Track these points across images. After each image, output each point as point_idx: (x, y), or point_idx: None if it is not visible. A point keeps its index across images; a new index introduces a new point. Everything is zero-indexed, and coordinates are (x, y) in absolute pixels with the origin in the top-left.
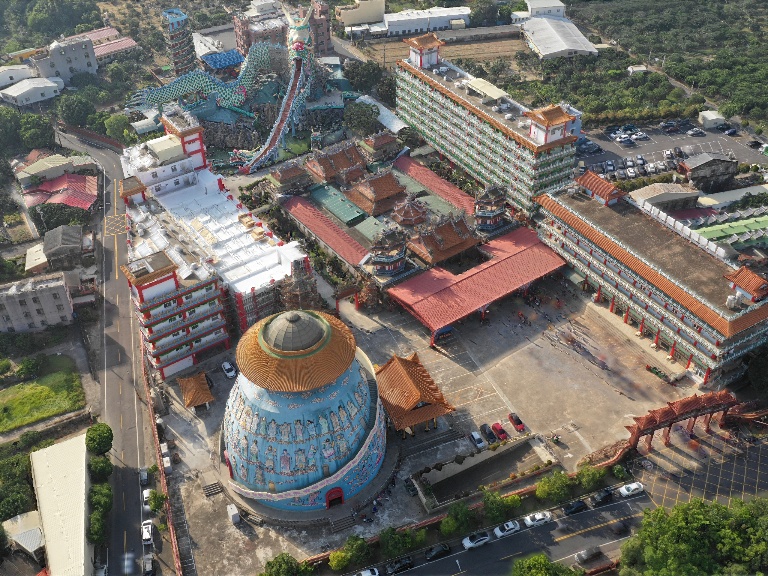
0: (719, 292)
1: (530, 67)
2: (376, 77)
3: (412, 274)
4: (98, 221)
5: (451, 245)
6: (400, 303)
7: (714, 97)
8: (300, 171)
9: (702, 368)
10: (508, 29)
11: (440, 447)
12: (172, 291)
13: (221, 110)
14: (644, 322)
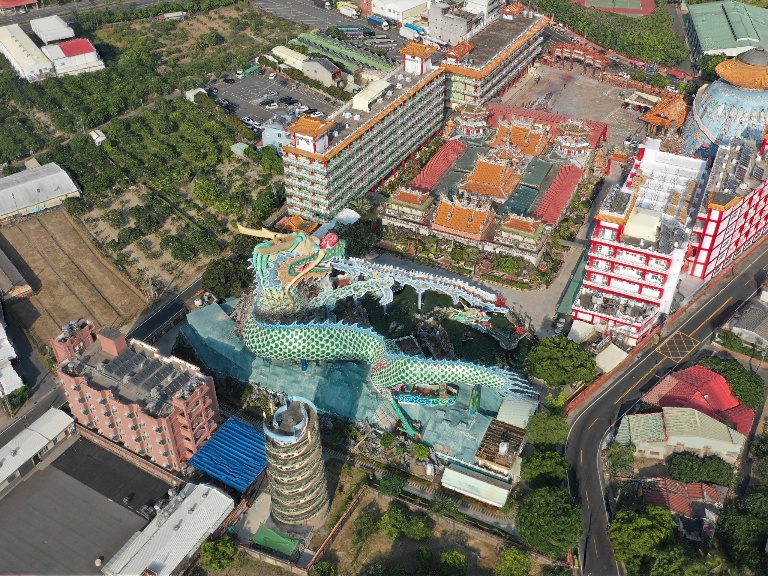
0: (522, 21)
1: None
2: None
3: None
4: (690, 364)
5: None
6: None
7: None
8: None
9: None
10: None
11: None
12: None
13: None
14: None
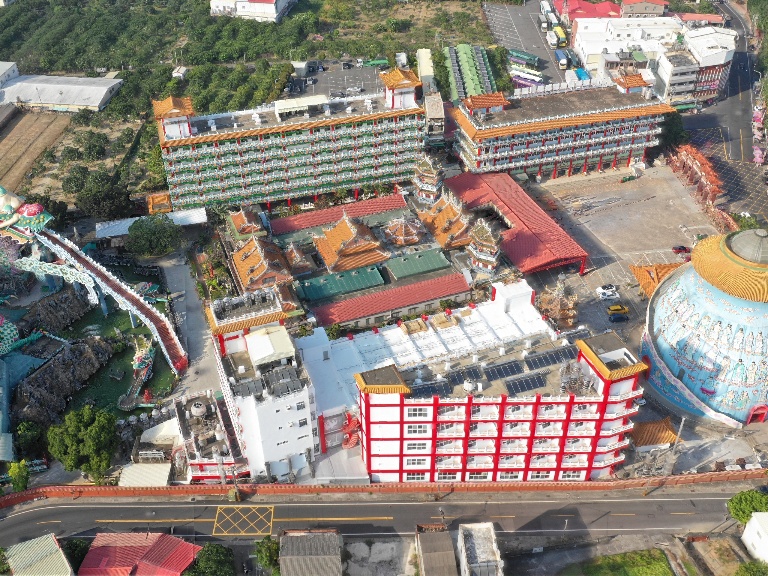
0: (631, 98)
1: (109, 121)
2: None
3: None
4: None
5: None
6: (541, 269)
7: (262, 57)
8: (285, 288)
9: (641, 155)
10: (5, 111)
11: None
12: None
13: (6, 360)
14: (588, 162)
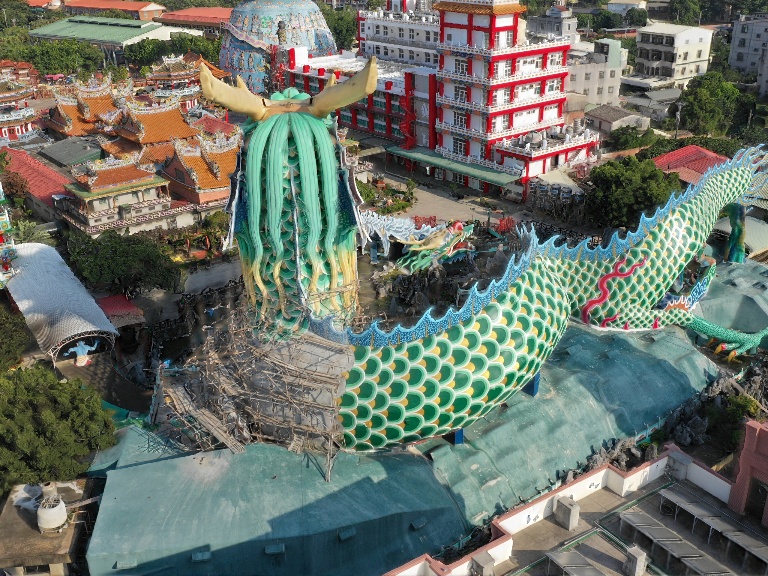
0: None
1: None
2: None
3: None
4: None
5: None
6: None
7: None
8: None
9: None
10: None
11: None
12: None
13: None
14: None
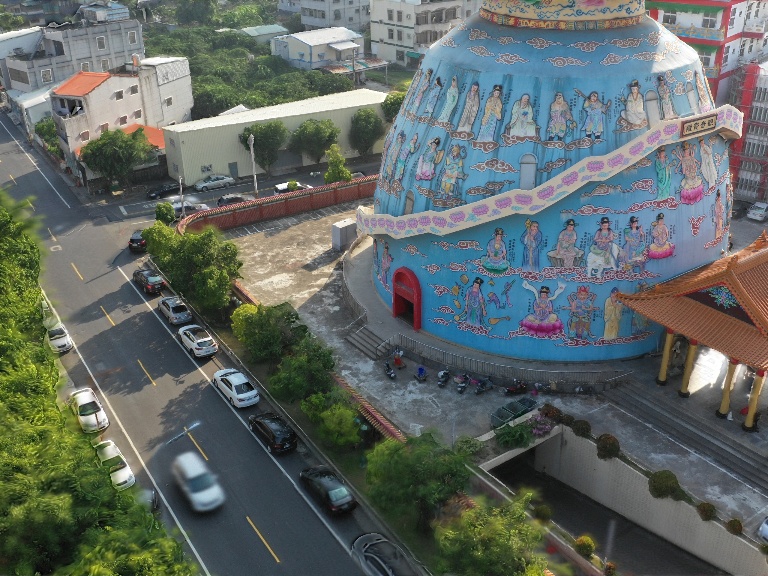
0: None
1: None
2: None
3: None
4: None
5: None
6: None
7: None
8: None
9: None
10: None
11: (692, 454)
12: None
13: None
14: None
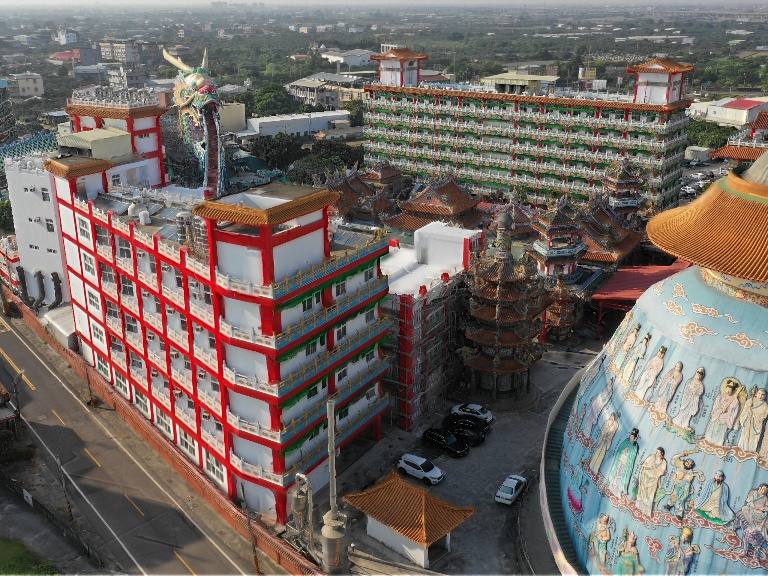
0: None
1: None
2: (298, 149)
3: (599, 278)
4: None
5: (621, 237)
6: None
7: None
8: None
9: None
10: None
11: None
12: (324, 260)
13: None
14: None
